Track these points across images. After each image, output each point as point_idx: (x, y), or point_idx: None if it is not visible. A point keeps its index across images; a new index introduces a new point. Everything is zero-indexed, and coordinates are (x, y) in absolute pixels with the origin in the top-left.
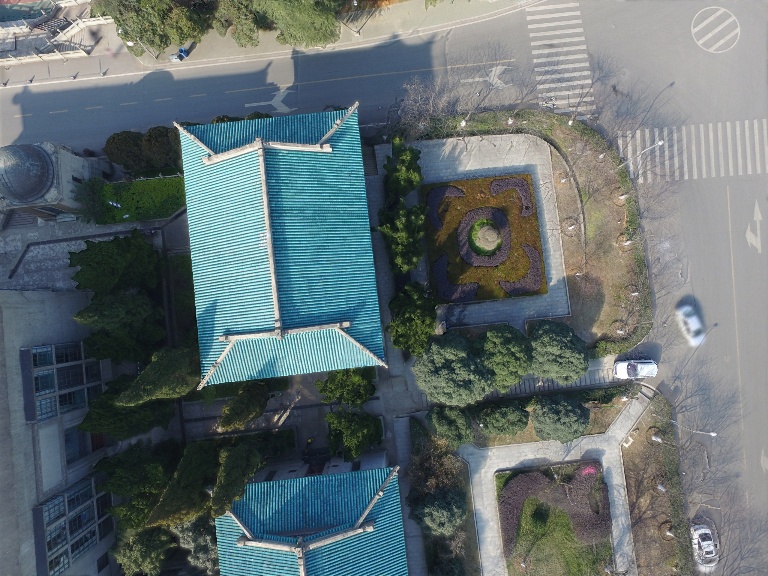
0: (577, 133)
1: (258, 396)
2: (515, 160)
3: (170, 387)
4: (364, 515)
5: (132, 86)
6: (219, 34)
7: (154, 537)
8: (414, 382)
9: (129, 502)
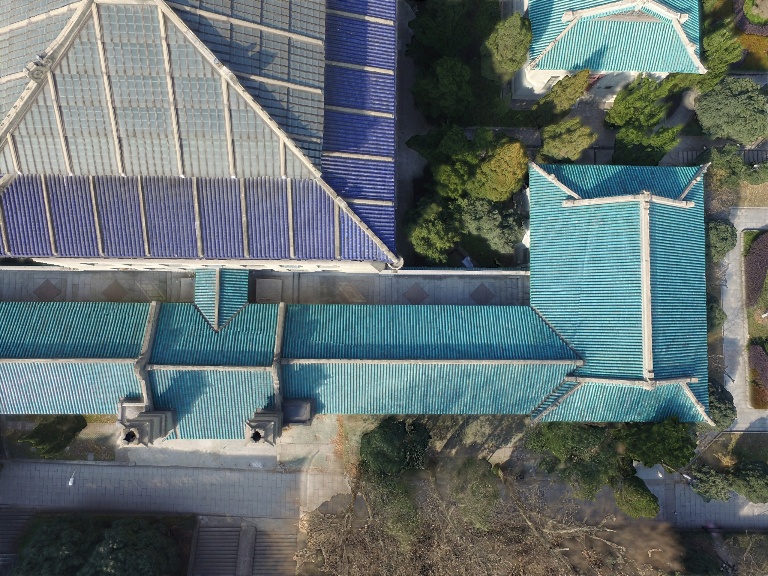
0: None
1: None
2: None
3: (530, 39)
4: (685, 193)
5: None
6: None
7: (449, 221)
8: None
9: (451, 166)
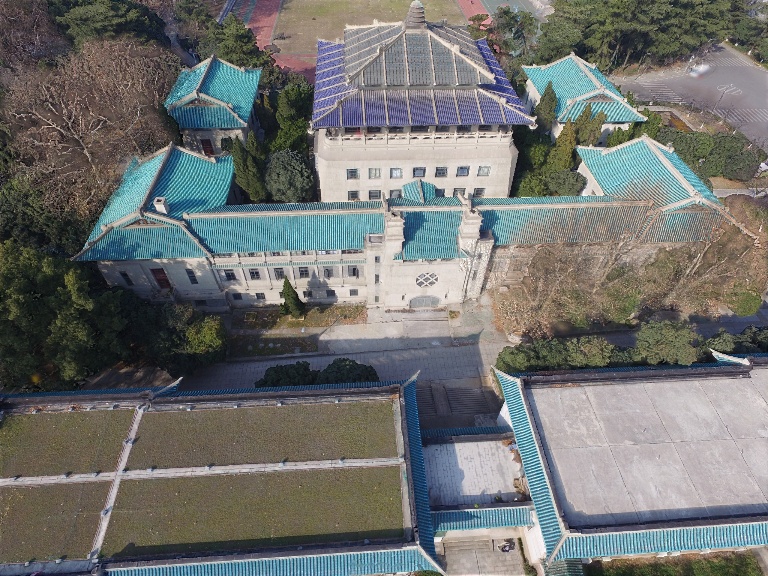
0: (685, 108)
1: None
2: None
3: None
4: None
5: None
6: None
7: None
8: None
9: None
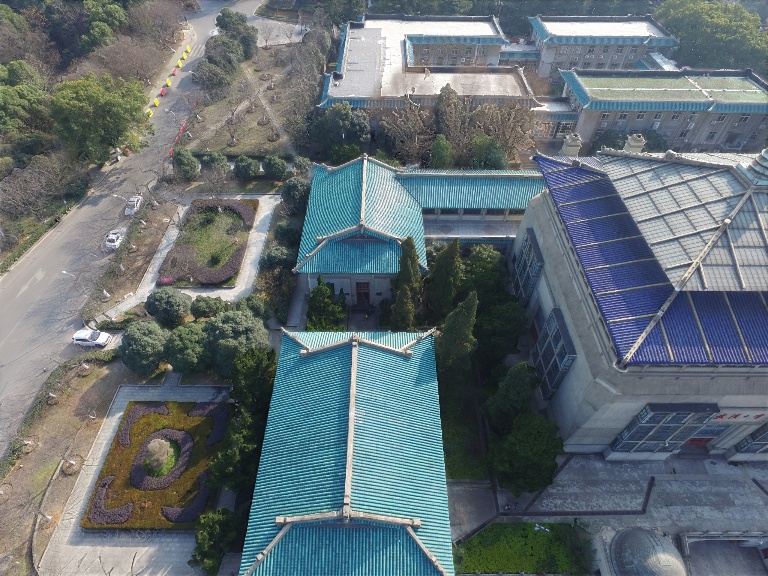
0: None
1: (393, 329)
2: (87, 554)
3: None
4: (321, 245)
5: None
6: None
7: None
8: (275, 350)
9: None
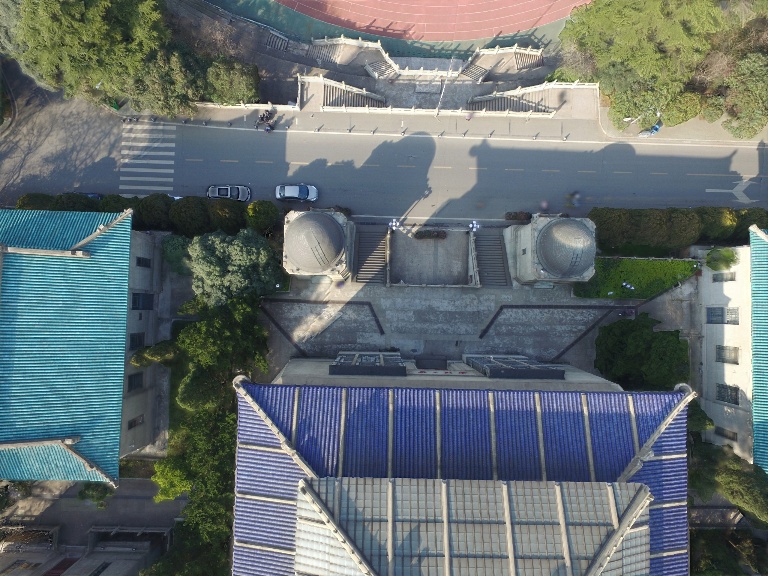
0: None
1: None
2: None
3: None
4: None
5: (592, 154)
6: (709, 120)
7: None
8: None
9: None
